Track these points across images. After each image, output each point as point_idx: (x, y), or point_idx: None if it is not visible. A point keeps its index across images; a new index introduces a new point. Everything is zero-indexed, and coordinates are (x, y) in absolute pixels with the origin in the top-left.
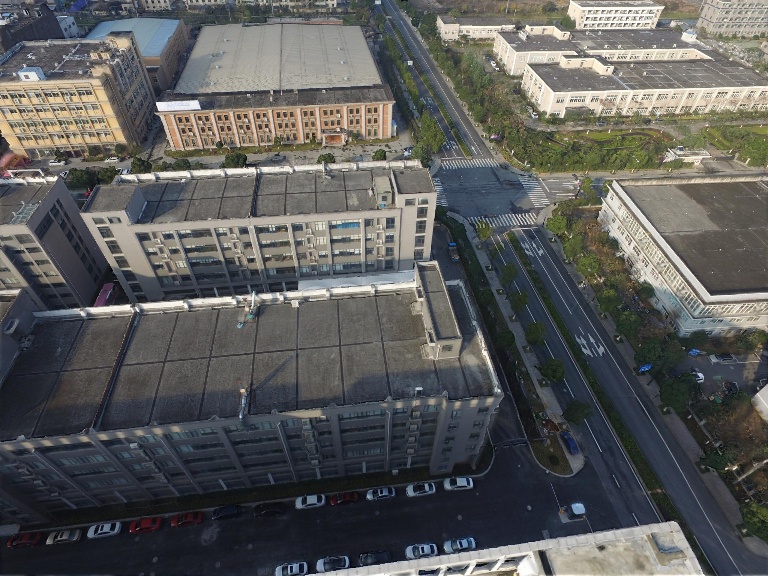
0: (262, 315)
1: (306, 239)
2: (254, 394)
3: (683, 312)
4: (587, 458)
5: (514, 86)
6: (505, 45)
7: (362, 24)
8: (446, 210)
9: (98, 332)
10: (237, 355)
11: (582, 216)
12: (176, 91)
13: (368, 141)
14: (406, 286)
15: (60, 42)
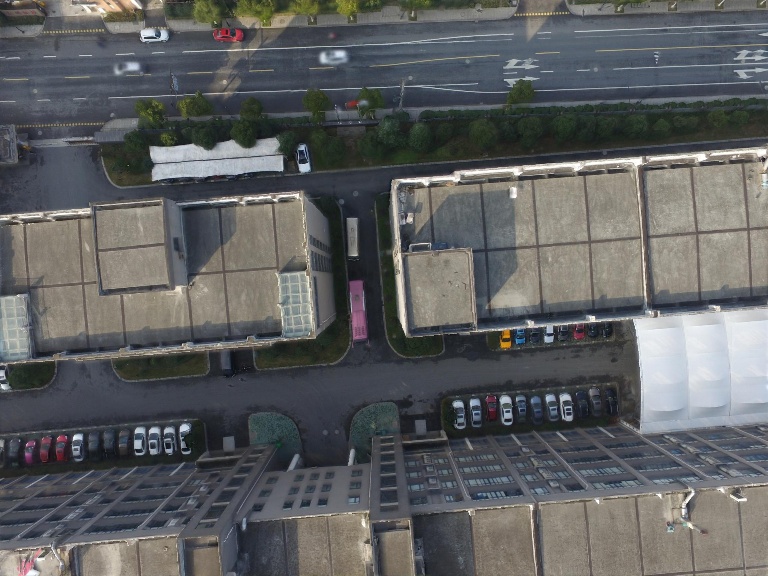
0: (694, 511)
1: None
2: None
3: None
4: None
5: None
6: None
7: None
8: None
9: (496, 533)
10: (675, 575)
11: None
12: None
13: None
14: None
15: None
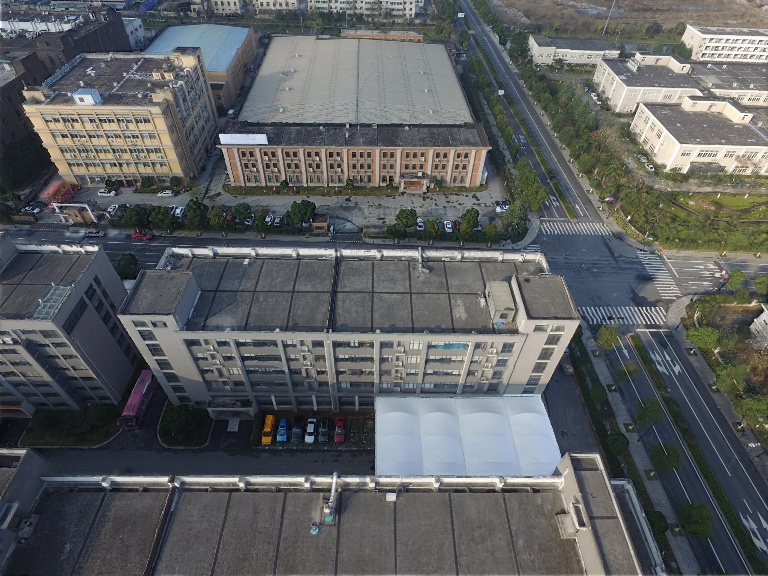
0: (345, 512)
1: (395, 357)
2: None
3: None
4: None
5: (621, 127)
6: (611, 76)
7: (443, 40)
8: None
9: (122, 518)
10: None
11: (726, 318)
12: (241, 116)
13: (452, 189)
14: (547, 480)
15: (122, 55)
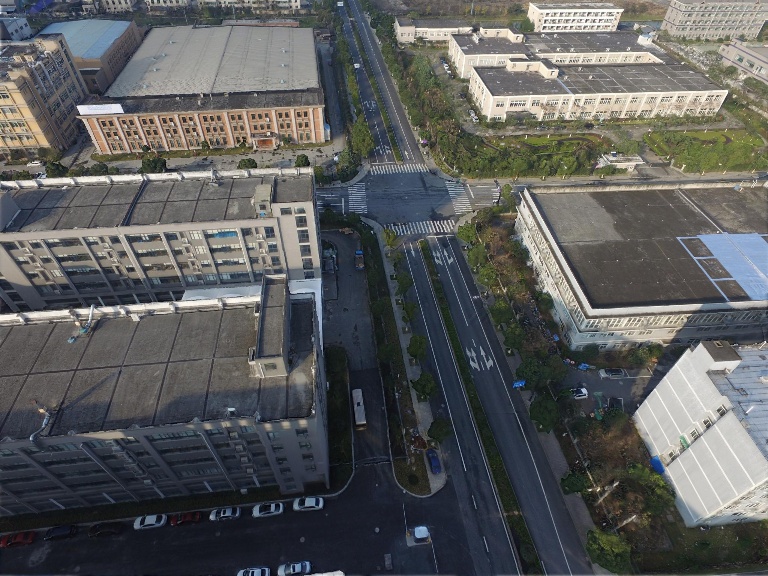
0: (99, 329)
1: (184, 248)
2: (61, 414)
3: (573, 325)
4: (449, 477)
5: (462, 89)
6: (457, 48)
7: (321, 26)
8: (358, 217)
9: None
10: (57, 372)
11: (501, 223)
12: (107, 94)
13: (300, 145)
14: (256, 299)
15: None
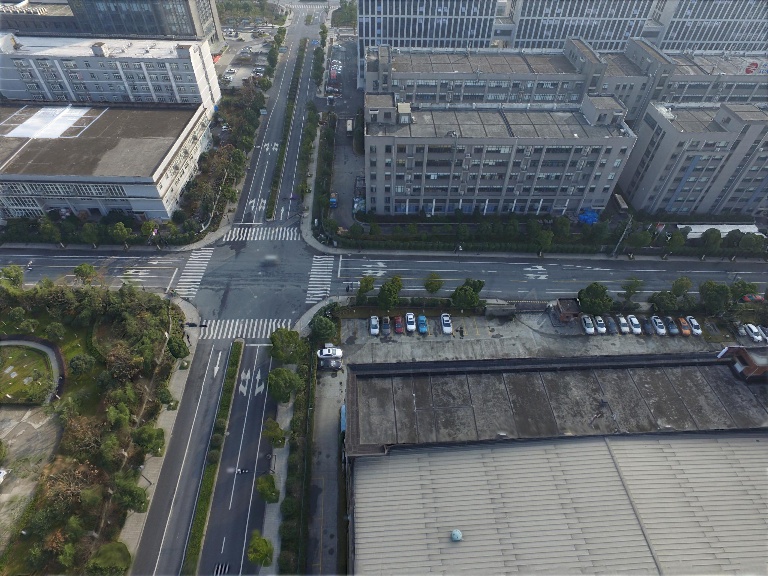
0: None
1: None
2: None
3: None
4: None
5: None
6: None
7: None
8: None
9: None
10: None
11: None
12: None
13: None
14: (397, 75)
15: None
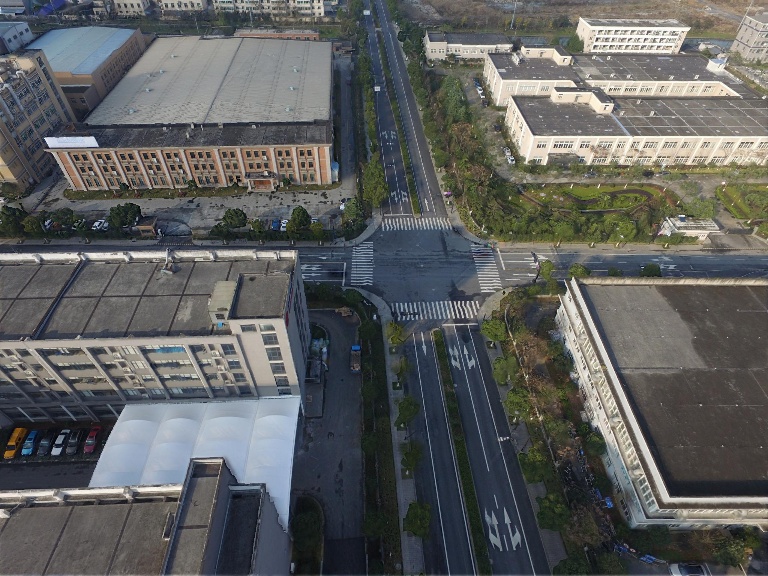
0: None
1: (117, 363)
2: None
3: None
4: None
5: (497, 120)
6: (493, 70)
7: (343, 37)
8: (359, 297)
9: None
10: None
11: (538, 310)
12: (88, 119)
13: (303, 187)
14: None
15: None
